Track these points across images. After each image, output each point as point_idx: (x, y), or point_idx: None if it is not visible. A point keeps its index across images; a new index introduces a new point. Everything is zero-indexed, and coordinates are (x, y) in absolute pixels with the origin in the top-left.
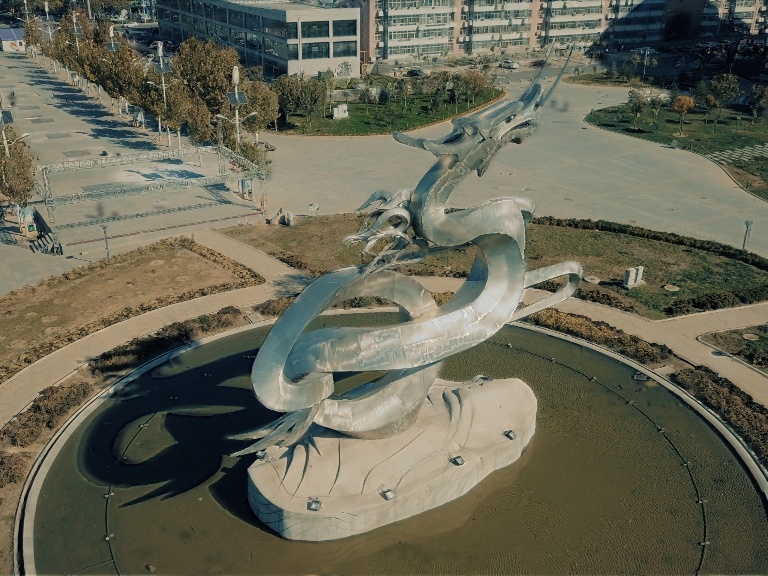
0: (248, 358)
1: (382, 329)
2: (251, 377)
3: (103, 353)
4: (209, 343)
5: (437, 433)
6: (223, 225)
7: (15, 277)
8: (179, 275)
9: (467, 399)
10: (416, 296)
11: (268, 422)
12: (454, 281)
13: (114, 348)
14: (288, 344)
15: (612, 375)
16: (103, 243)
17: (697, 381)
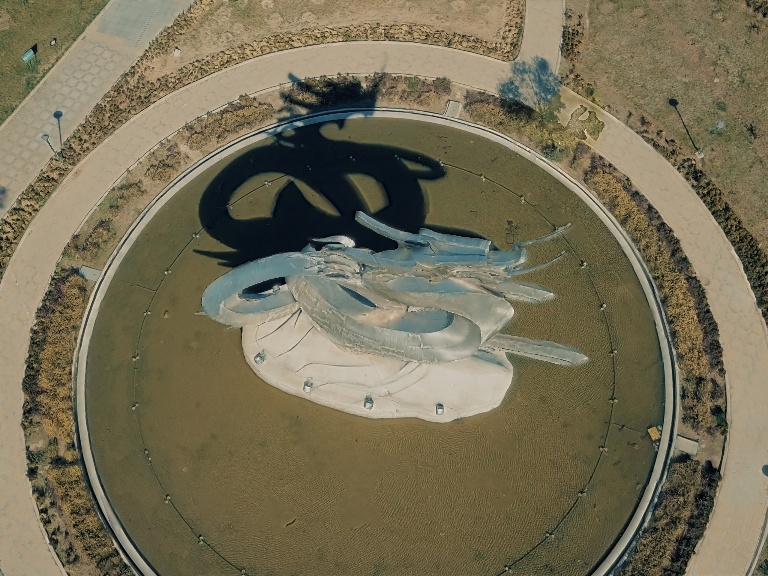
0: (397, 159)
1: (334, 306)
2: (204, 292)
3: (308, 80)
4: (390, 118)
5: (379, 373)
6: None
7: None
8: None
9: (427, 364)
10: (382, 298)
11: (353, 235)
12: (677, 181)
13: (322, 77)
14: (235, 288)
15: (637, 410)
16: None
17: (684, 482)
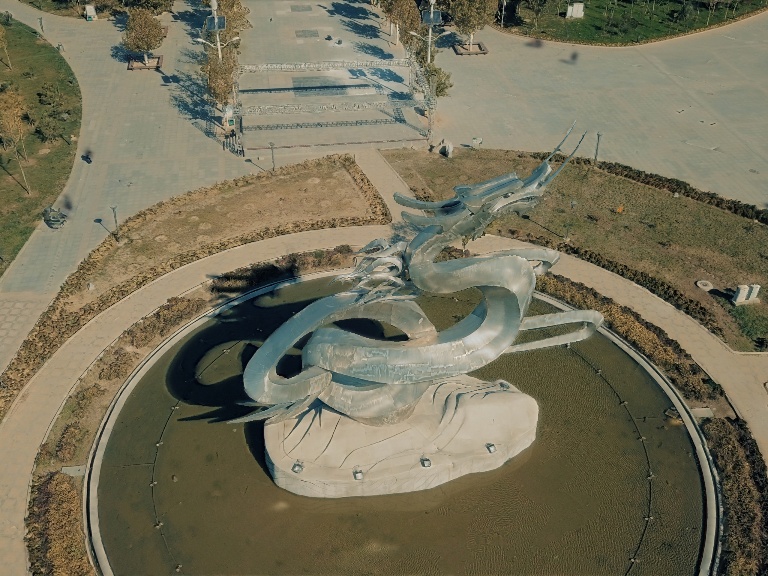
0: None
1: (373, 347)
2: (244, 373)
3: (226, 273)
4: (312, 280)
5: (421, 433)
6: (389, 146)
7: (199, 175)
8: (324, 199)
9: (462, 408)
10: (414, 322)
11: None
12: (563, 257)
13: (237, 269)
14: (278, 352)
15: (646, 403)
16: (279, 151)
17: (722, 435)
